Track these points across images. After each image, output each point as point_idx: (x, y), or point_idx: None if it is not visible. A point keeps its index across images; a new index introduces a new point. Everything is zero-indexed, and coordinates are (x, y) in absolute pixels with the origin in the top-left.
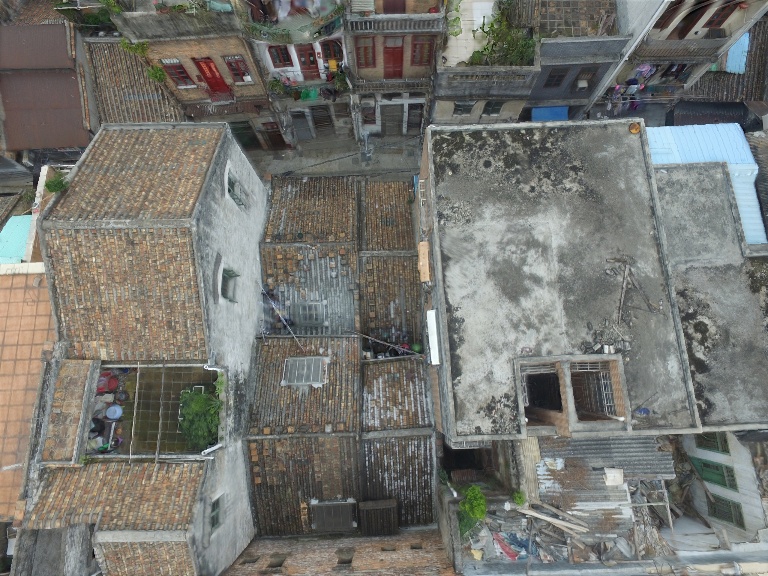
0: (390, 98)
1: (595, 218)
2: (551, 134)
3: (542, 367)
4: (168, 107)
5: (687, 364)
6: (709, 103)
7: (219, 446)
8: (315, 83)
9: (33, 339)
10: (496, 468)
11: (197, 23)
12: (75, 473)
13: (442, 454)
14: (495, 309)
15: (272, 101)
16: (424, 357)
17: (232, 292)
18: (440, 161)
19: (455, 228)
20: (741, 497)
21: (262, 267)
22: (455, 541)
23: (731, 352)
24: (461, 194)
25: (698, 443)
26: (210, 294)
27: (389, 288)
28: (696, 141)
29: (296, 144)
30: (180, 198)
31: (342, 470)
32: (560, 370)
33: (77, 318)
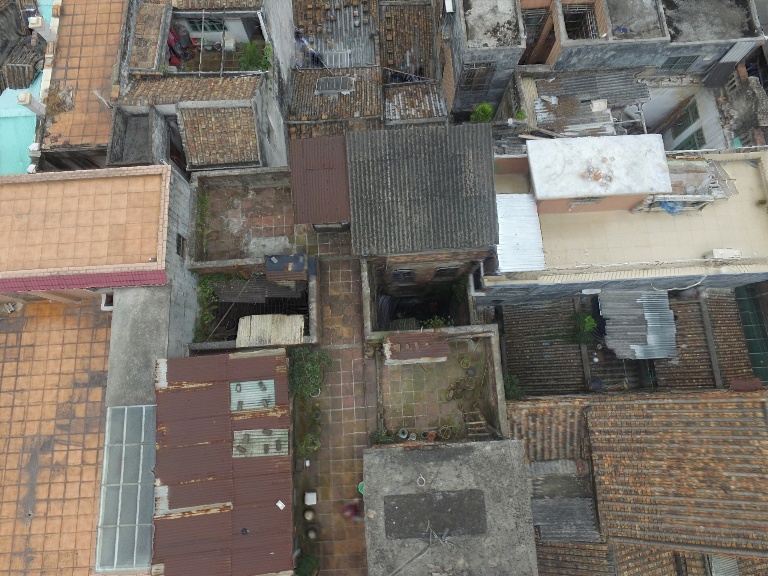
0: None
1: None
2: None
3: (538, 10)
4: None
5: None
6: None
7: None
8: None
9: (109, 20)
10: None
11: None
12: (155, 82)
13: None
14: None
15: None
16: (437, 82)
17: None
18: None
19: None
20: (708, 146)
21: (294, 18)
22: None
23: None
24: None
25: (675, 135)
26: None
27: (405, 37)
28: None
29: None
30: None
31: None
32: (553, 8)
33: None
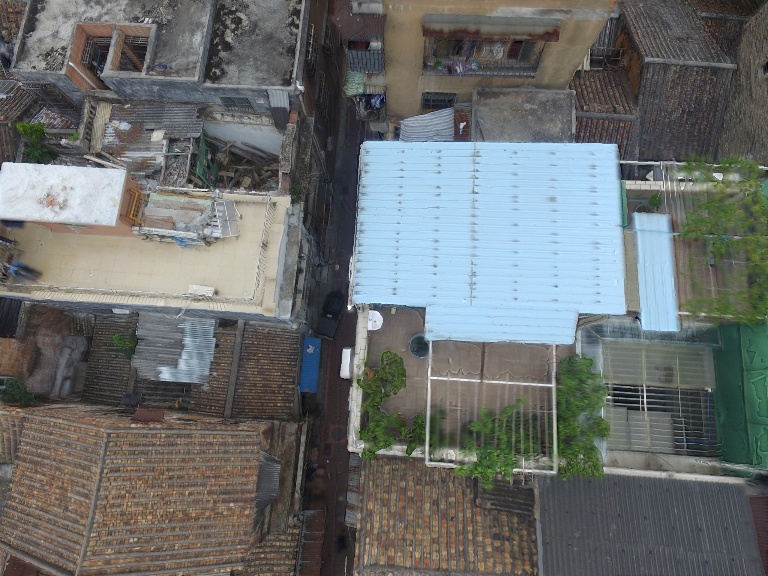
0: None
1: None
2: None
3: (106, 39)
4: None
5: (203, 35)
6: None
7: None
8: None
9: None
10: None
11: None
12: None
13: None
14: None
15: None
16: None
17: None
18: None
19: None
20: None
21: None
22: (16, 161)
23: (253, 39)
24: None
25: None
26: None
27: None
28: None
29: None
30: None
31: (4, 158)
32: None
33: None
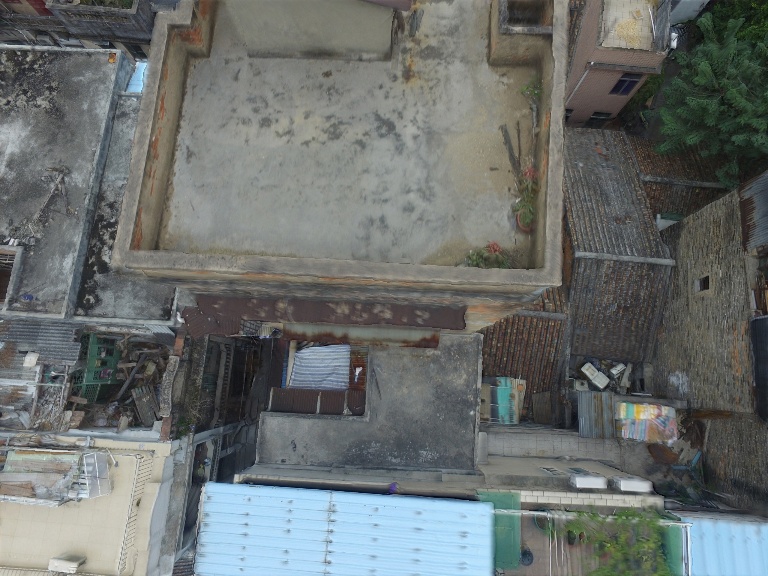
0: (67, 38)
1: (51, 132)
2: (41, 57)
3: None
4: None
5: (74, 261)
6: None
7: None
8: None
9: None
10: None
11: None
12: None
13: None
14: None
15: None
16: None
17: None
18: None
19: None
20: None
21: None
22: None
23: None
24: None
25: None
26: None
27: None
28: None
29: None
30: None
31: None
32: None
33: None
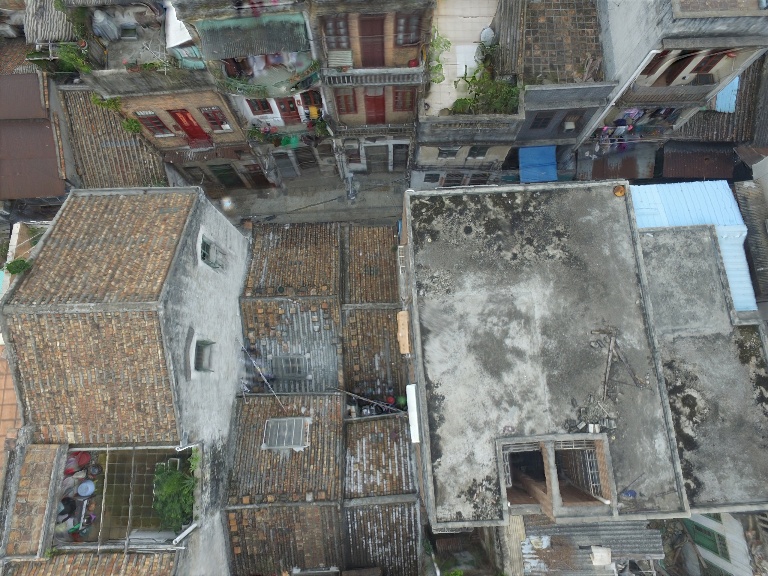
0: (374, 140)
1: (579, 287)
2: (533, 197)
3: (525, 445)
4: (146, 154)
5: (675, 443)
6: (699, 142)
7: (193, 527)
8: (296, 128)
9: (1, 414)
10: (482, 537)
11: (170, 79)
12: (41, 566)
13: (426, 522)
14: (476, 385)
15: (252, 147)
16: None
17: (208, 360)
18: (419, 227)
19: (435, 299)
20: (733, 568)
21: (243, 321)
22: None
23: (720, 427)
24: (441, 262)
25: None
26: (181, 373)
27: (373, 341)
28: (683, 200)
29: (280, 182)
30: (148, 277)
31: (324, 538)
32: (544, 449)
33: (42, 402)
